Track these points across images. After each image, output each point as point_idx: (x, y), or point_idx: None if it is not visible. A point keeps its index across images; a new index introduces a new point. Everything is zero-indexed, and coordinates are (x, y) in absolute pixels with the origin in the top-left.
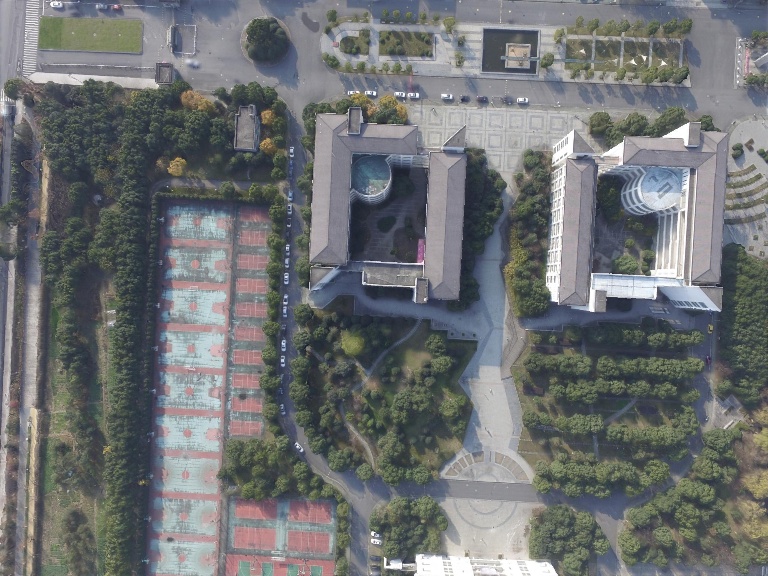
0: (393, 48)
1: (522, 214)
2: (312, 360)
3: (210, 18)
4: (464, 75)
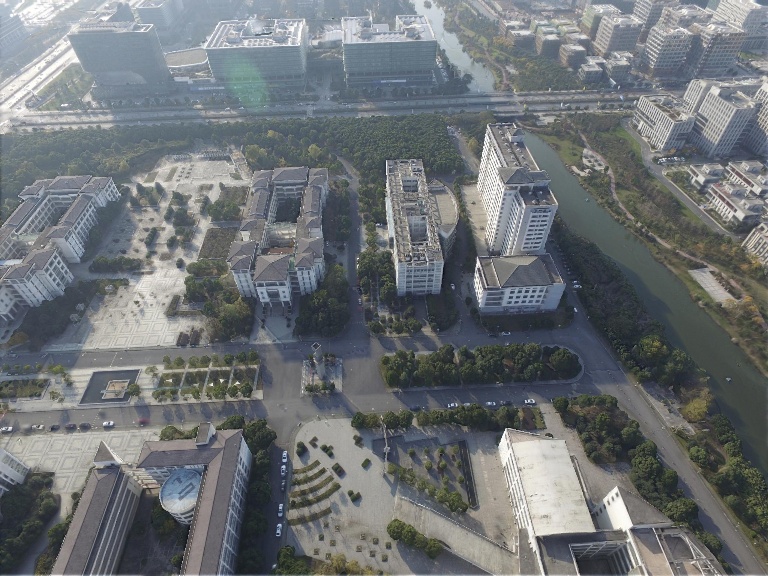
0: (5, 393)
1: None
2: None
3: None
4: (62, 408)
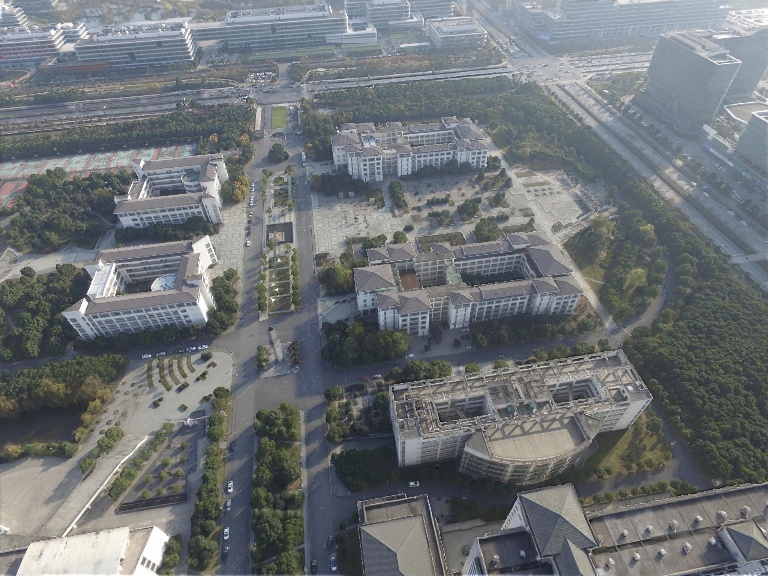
0: None
1: None
2: None
3: (290, 142)
4: (264, 219)
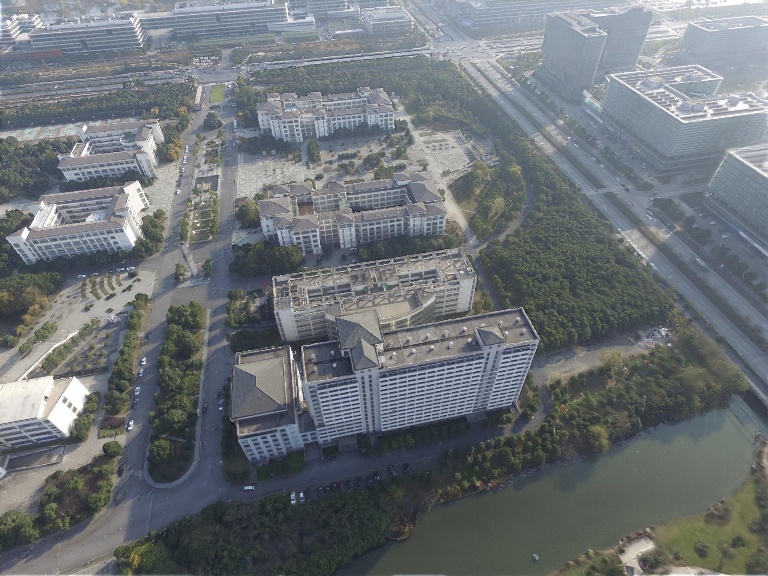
0: None
1: None
2: None
3: (225, 113)
4: None
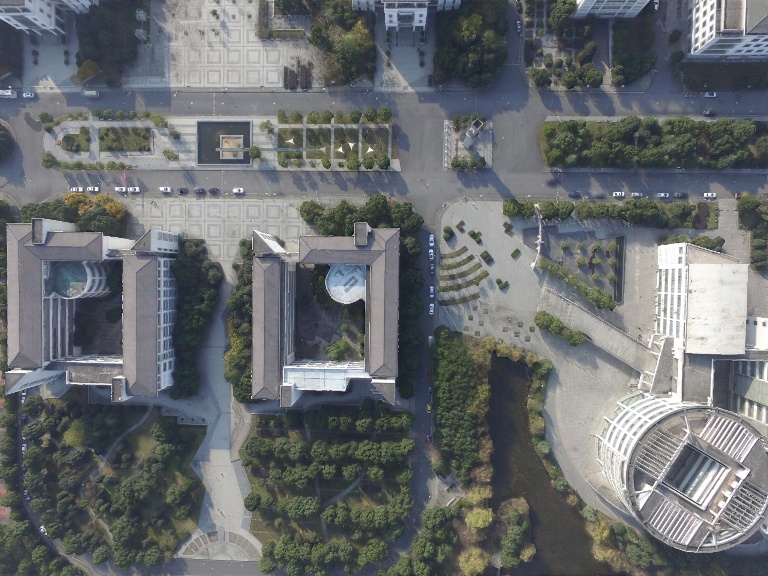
0: (111, 145)
1: (229, 306)
2: (47, 449)
3: None
4: (181, 168)
